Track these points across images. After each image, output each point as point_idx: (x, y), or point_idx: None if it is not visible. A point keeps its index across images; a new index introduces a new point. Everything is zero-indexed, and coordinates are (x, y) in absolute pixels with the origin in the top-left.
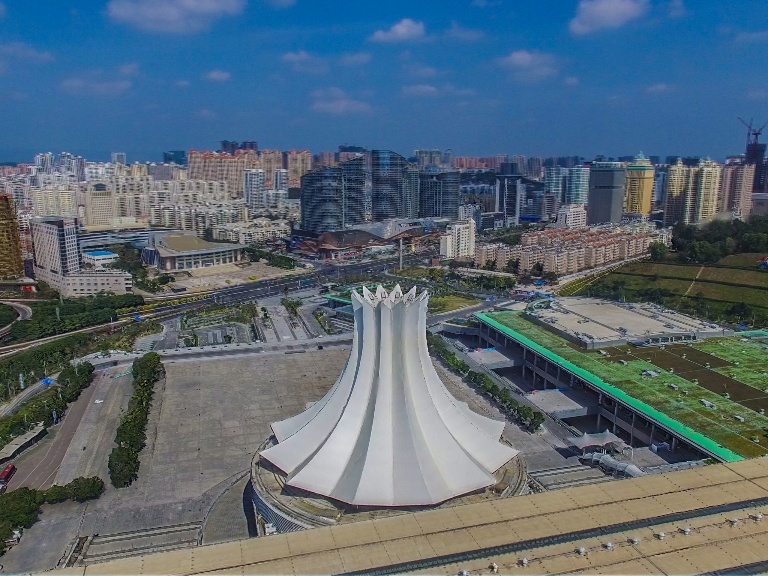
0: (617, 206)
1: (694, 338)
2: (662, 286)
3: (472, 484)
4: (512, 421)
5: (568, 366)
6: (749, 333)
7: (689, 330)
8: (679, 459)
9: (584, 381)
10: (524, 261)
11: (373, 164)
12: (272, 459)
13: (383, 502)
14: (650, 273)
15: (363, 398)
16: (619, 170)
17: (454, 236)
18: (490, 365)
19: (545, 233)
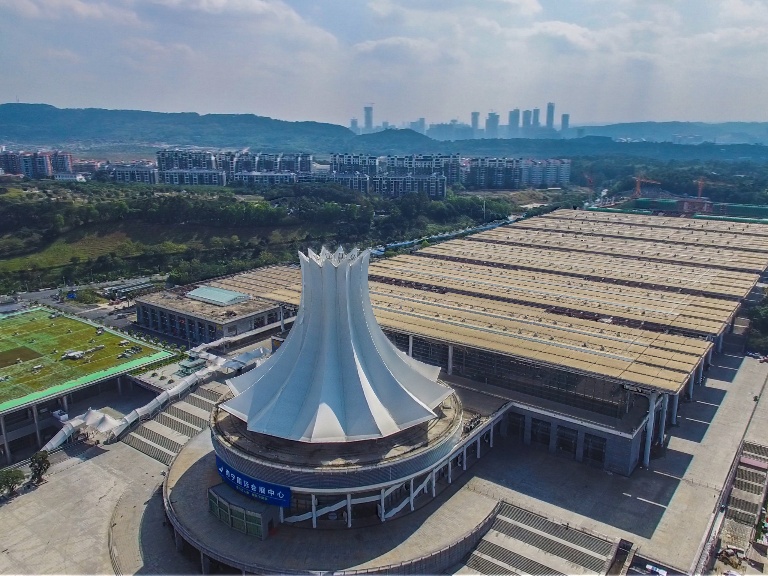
0: None
1: None
2: None
3: None
4: (2, 504)
5: None
6: None
7: None
8: (81, 409)
9: None
10: None
11: None
12: None
13: None
14: None
15: None
16: None
17: None
18: None
19: None
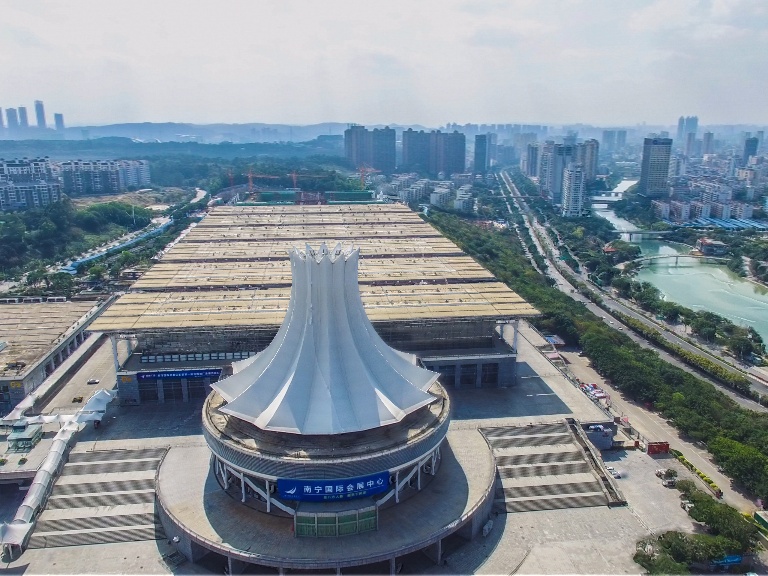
0: None
1: None
2: None
3: None
4: None
5: None
6: None
7: None
8: None
9: None
10: None
11: None
12: None
13: None
14: None
15: None
16: None
17: None
18: None
19: None
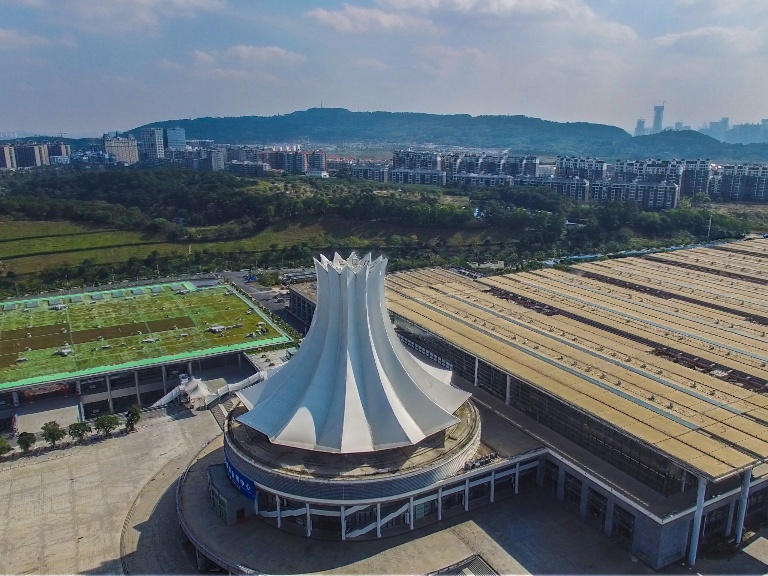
0: None
1: None
2: None
3: None
4: (97, 442)
5: (13, 384)
6: None
7: None
8: (203, 377)
9: (64, 380)
10: None
11: None
12: None
13: None
14: None
15: None
16: None
17: None
18: None
19: None
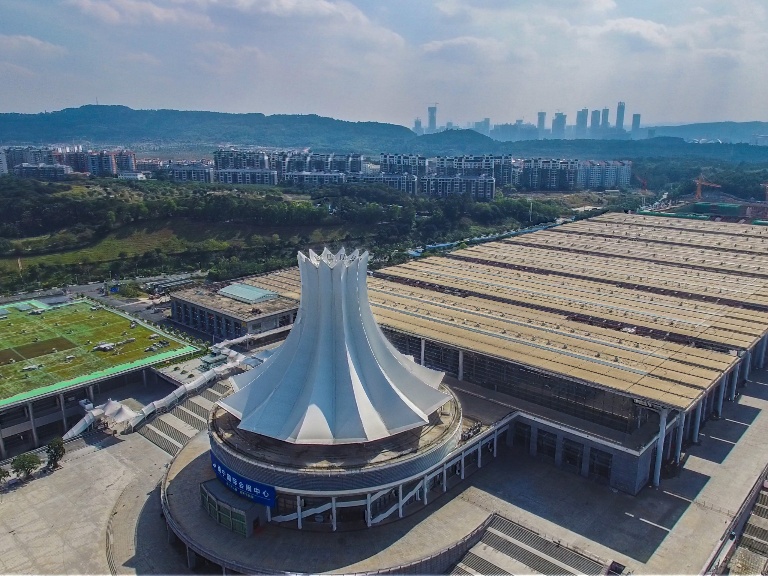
0: None
1: None
2: None
3: None
4: (18, 487)
5: None
6: None
7: None
8: (106, 399)
9: None
10: None
11: None
12: None
13: None
14: None
15: None
16: None
17: None
18: None
19: None
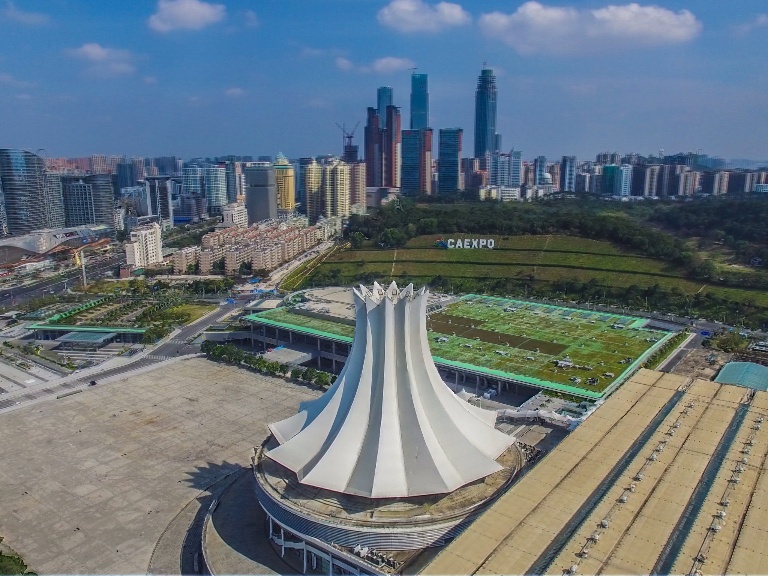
0: (273, 203)
1: (441, 307)
2: (371, 270)
3: (501, 446)
4: None
5: None
6: (468, 297)
7: (434, 301)
8: (508, 399)
9: None
10: (231, 261)
11: (2, 166)
12: (318, 484)
13: (460, 483)
14: (356, 260)
15: (392, 396)
16: (271, 169)
17: (141, 243)
18: (293, 362)
19: (223, 233)
